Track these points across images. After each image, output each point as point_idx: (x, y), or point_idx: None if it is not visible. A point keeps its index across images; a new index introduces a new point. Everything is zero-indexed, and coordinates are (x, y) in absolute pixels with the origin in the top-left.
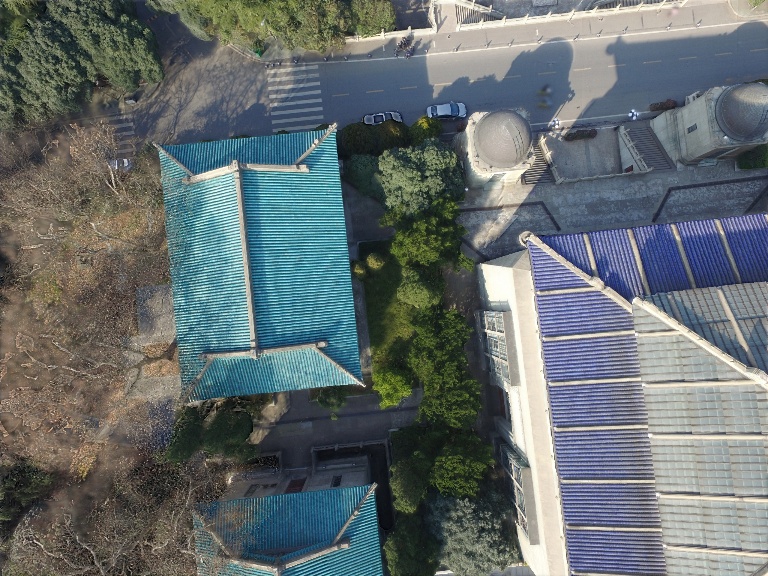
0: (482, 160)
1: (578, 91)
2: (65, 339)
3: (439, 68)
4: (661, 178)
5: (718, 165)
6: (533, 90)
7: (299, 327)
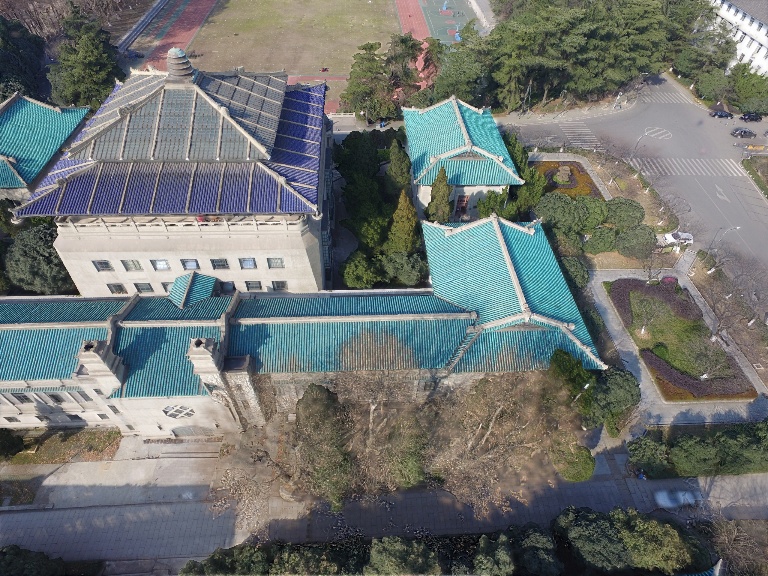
0: None
1: None
2: None
3: None
4: None
5: None
6: None
7: (3, 151)
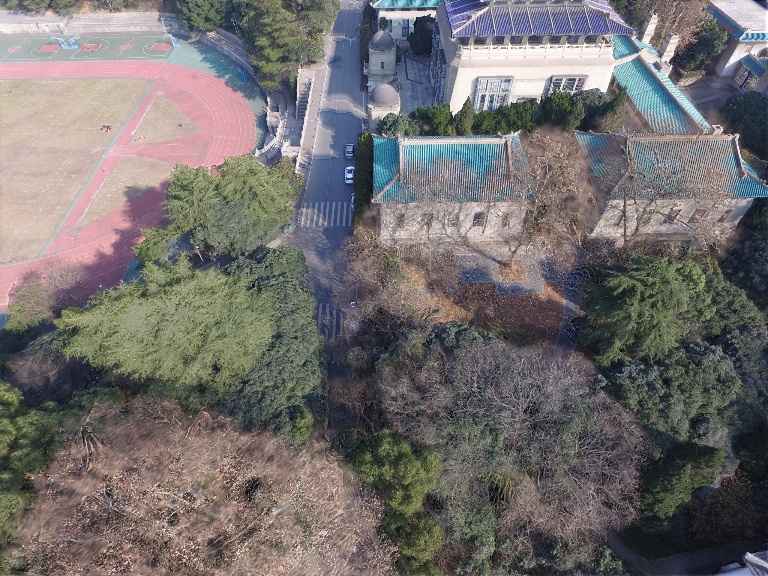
0: (394, 105)
1: (348, 111)
2: (501, 329)
3: (322, 155)
4: (402, 81)
5: None
6: (344, 124)
7: None
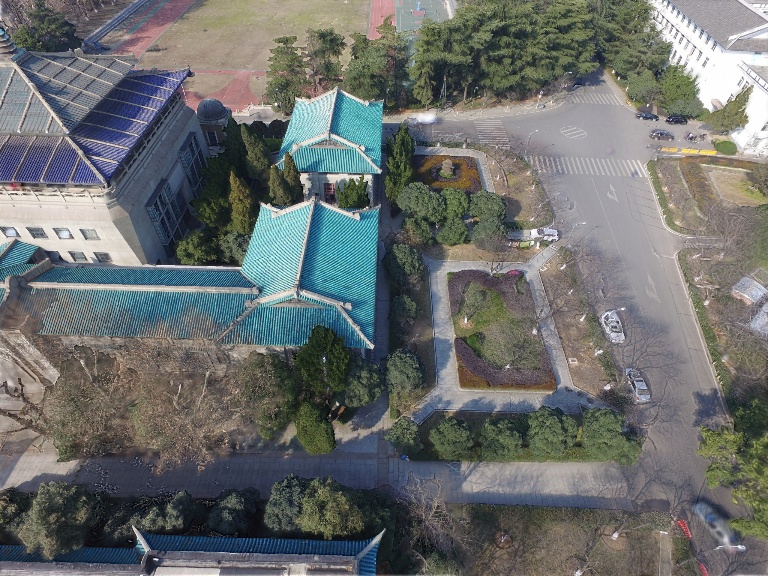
0: None
1: None
2: None
3: None
4: None
5: (221, 150)
6: None
7: None
